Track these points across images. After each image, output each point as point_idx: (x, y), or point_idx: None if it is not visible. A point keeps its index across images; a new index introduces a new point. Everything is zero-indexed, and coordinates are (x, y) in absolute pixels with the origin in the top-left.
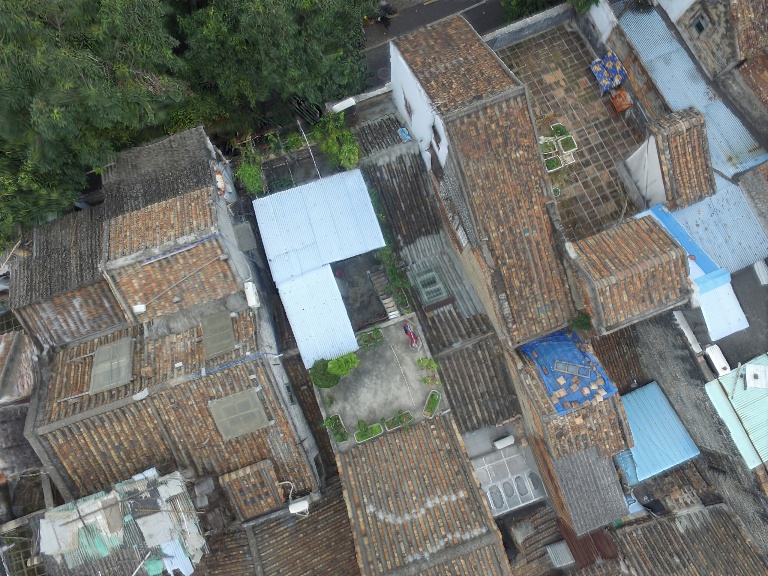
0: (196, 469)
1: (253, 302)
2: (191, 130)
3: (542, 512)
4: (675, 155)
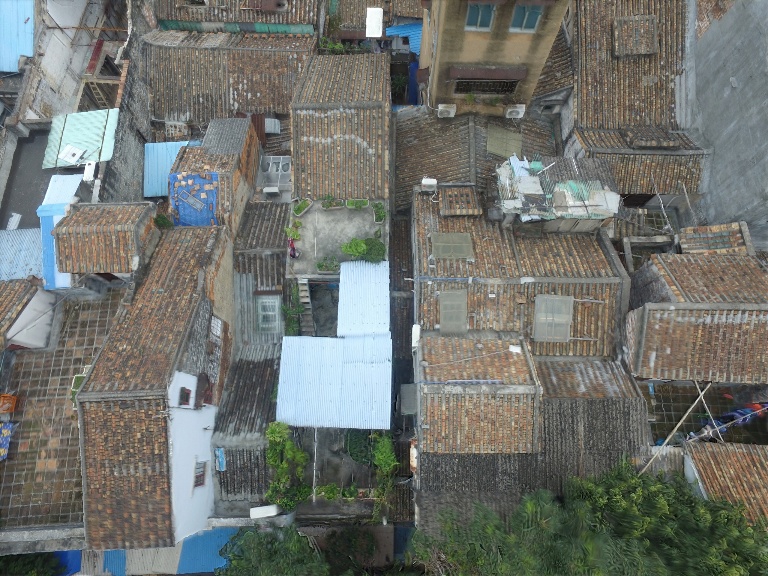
0: (500, 226)
1: (415, 327)
2: None
3: (272, 153)
4: (3, 315)
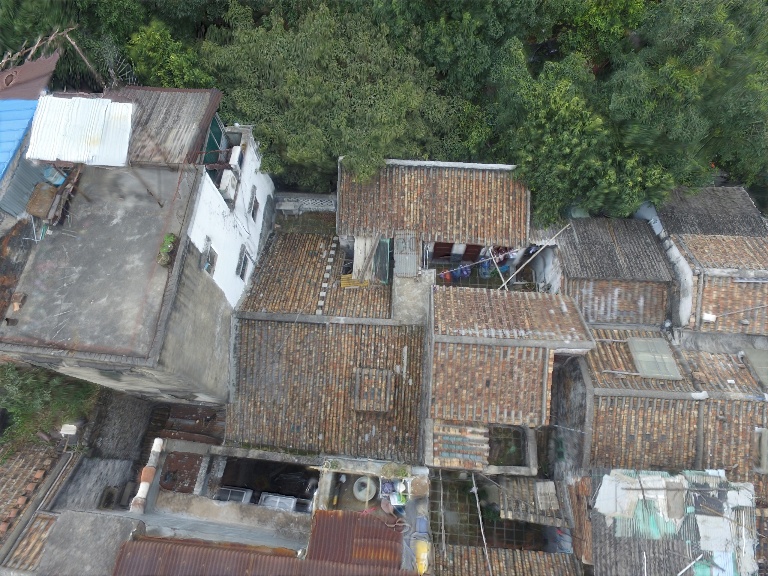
0: None
1: None
2: (733, 188)
3: None
4: None
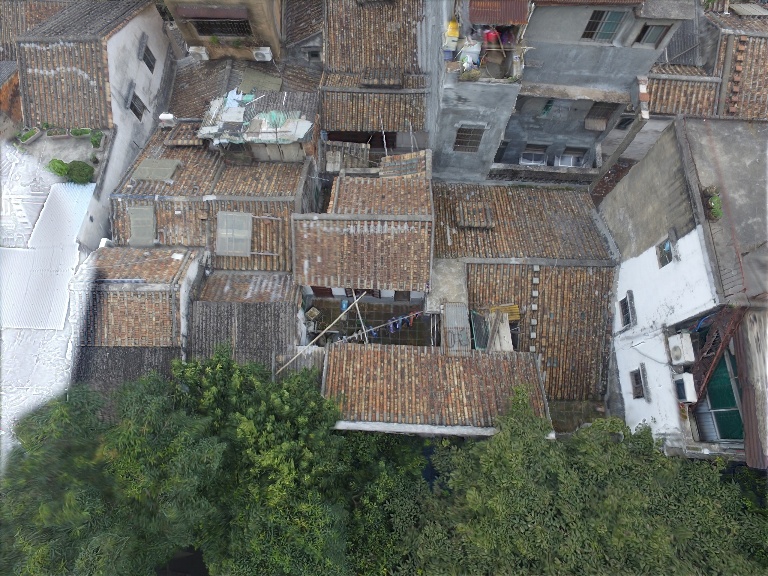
0: (218, 156)
1: (102, 240)
2: None
3: None
4: None
